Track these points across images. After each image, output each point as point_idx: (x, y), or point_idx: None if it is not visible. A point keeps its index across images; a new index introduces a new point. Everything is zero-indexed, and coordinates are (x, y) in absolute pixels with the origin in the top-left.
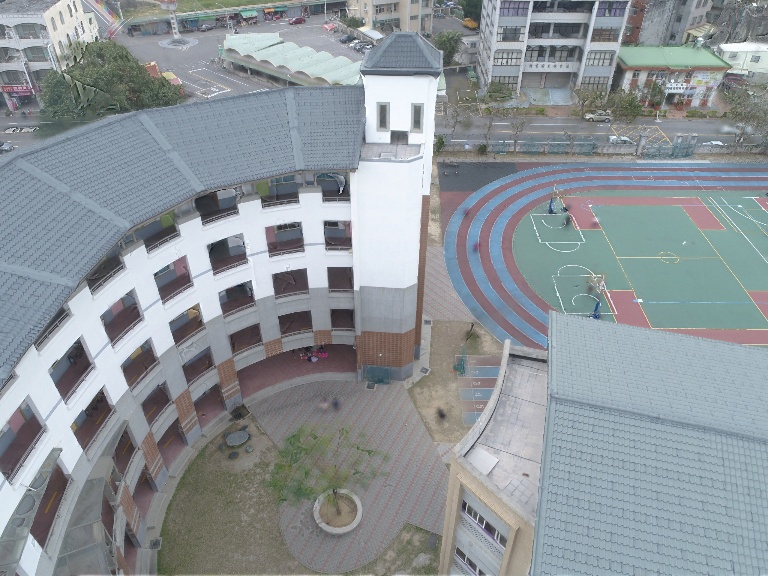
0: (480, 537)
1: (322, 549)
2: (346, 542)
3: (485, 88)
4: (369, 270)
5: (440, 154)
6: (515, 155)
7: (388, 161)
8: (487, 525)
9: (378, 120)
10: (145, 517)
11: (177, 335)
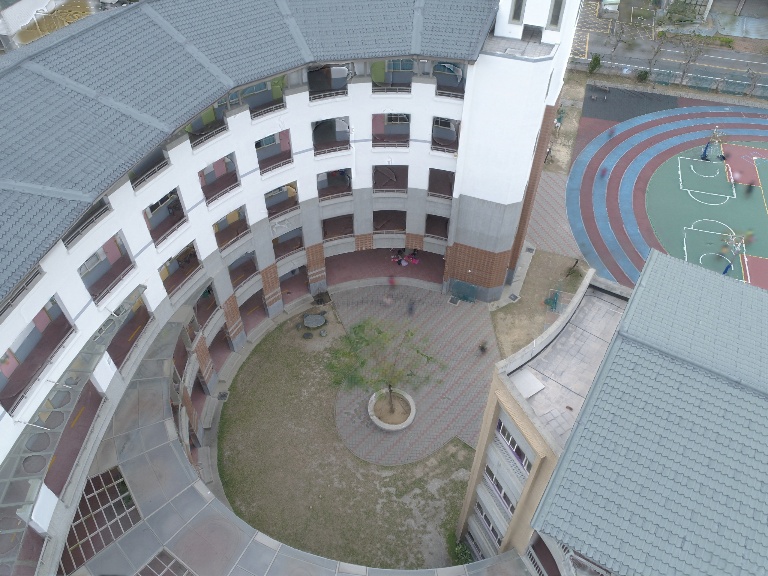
0: (509, 460)
1: (369, 439)
2: (393, 439)
3: (666, 8)
4: (472, 178)
5: (592, 76)
6: (680, 88)
7: (512, 57)
8: (518, 449)
9: (512, 10)
10: (219, 371)
11: (274, 210)
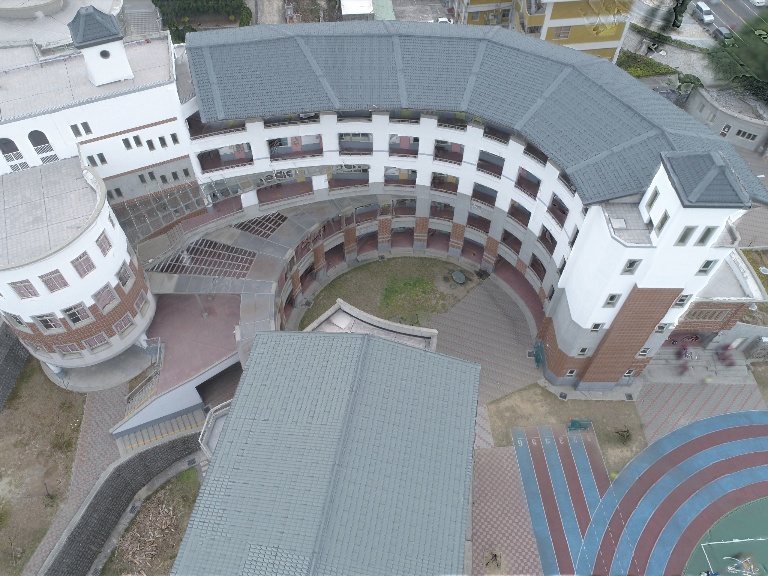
0: None
1: None
2: None
3: None
4: (571, 284)
5: None
6: None
7: (608, 223)
8: None
9: (650, 199)
10: (396, 247)
11: None
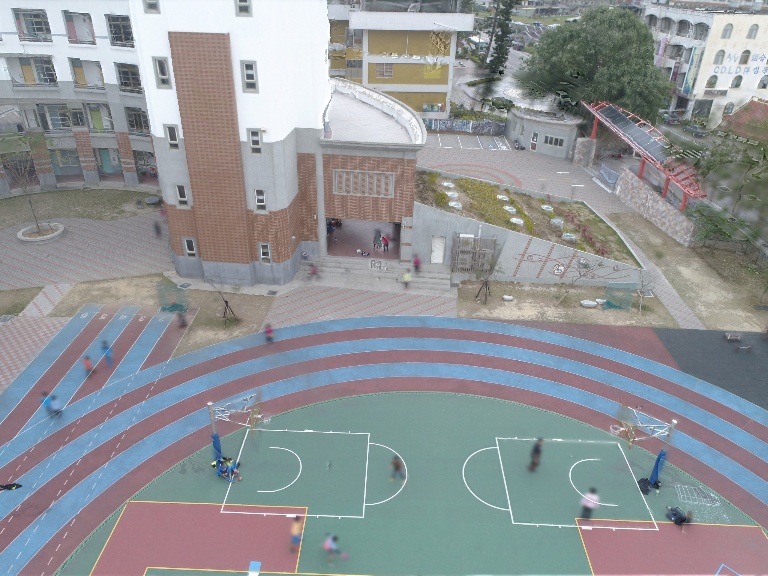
0: None
1: (18, 231)
2: (13, 239)
3: None
4: None
5: None
6: None
7: None
8: None
9: None
10: (107, 181)
11: None
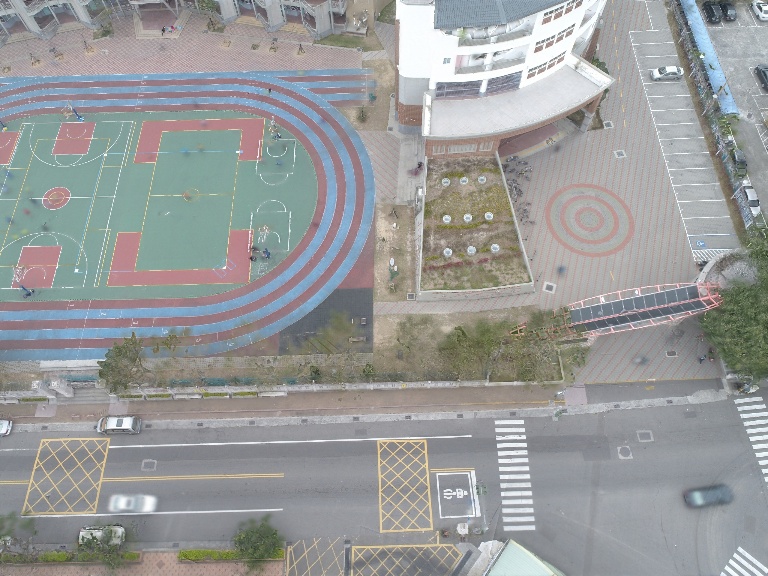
0: None
1: None
2: None
3: None
4: None
5: None
6: None
7: None
8: None
9: None
10: None
11: None
